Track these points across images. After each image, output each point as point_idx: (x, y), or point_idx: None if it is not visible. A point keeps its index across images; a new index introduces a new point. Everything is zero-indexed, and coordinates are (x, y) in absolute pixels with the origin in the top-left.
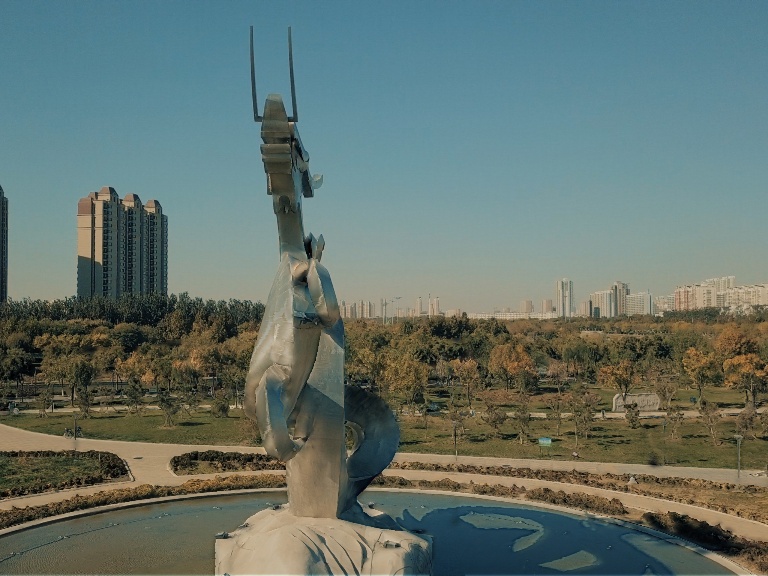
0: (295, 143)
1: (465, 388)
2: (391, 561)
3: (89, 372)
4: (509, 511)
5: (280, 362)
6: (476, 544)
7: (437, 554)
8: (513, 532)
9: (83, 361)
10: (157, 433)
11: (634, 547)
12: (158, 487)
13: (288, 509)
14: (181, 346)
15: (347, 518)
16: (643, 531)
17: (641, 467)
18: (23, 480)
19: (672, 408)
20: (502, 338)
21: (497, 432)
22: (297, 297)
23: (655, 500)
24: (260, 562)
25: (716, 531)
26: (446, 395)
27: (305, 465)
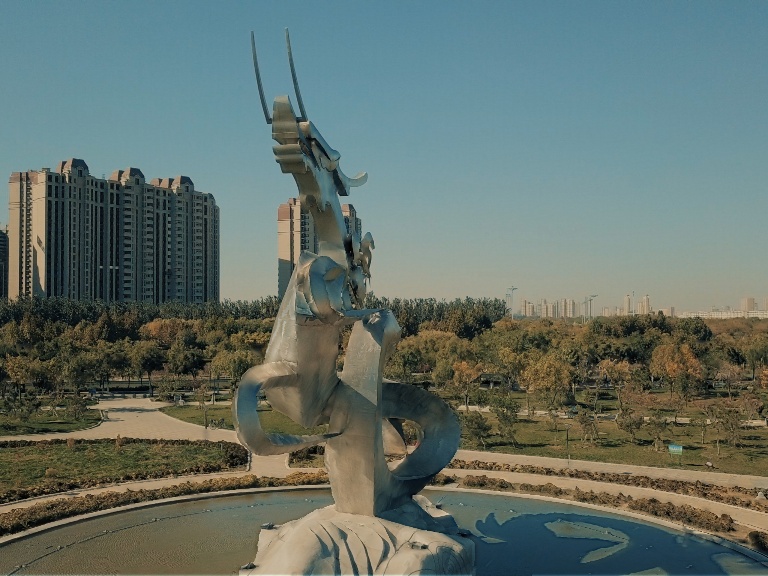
0: (316, 143)
1: (616, 390)
2: (408, 562)
3: (245, 368)
4: (602, 521)
5: (287, 358)
6: (549, 553)
7: (510, 560)
8: (593, 543)
9: (240, 357)
10: (293, 427)
11: (720, 568)
12: None
13: None
14: (342, 344)
15: (387, 516)
16: (739, 551)
17: None
18: (151, 466)
19: None
20: (676, 338)
21: (633, 437)
22: (301, 295)
23: None
24: None
25: None
26: (605, 397)
27: (341, 461)
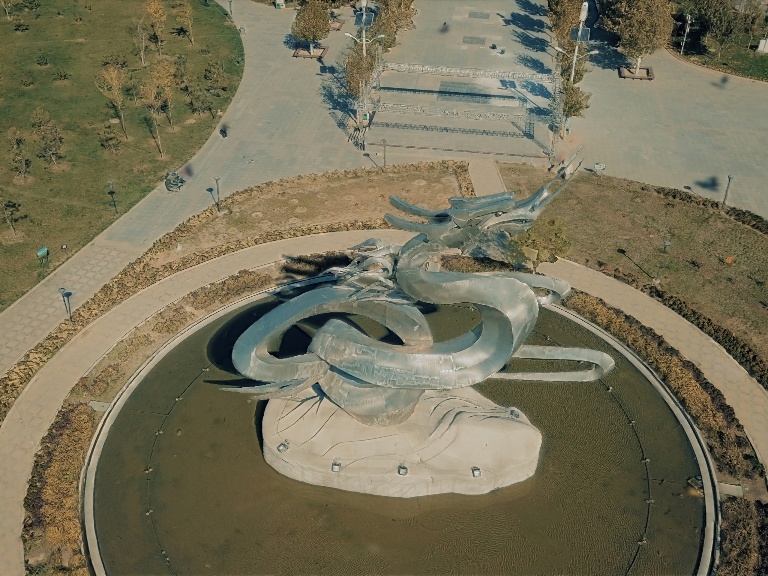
0: None
1: None
2: None
3: None
4: (235, 327)
5: None
6: None
7: None
8: (294, 337)
9: None
10: None
11: None
12: (32, 572)
13: (369, 428)
14: None
15: None
16: (319, 282)
17: (118, 228)
18: None
19: (18, 153)
20: None
21: None
22: None
23: (237, 254)
24: (491, 445)
25: (345, 257)
26: None
27: None
